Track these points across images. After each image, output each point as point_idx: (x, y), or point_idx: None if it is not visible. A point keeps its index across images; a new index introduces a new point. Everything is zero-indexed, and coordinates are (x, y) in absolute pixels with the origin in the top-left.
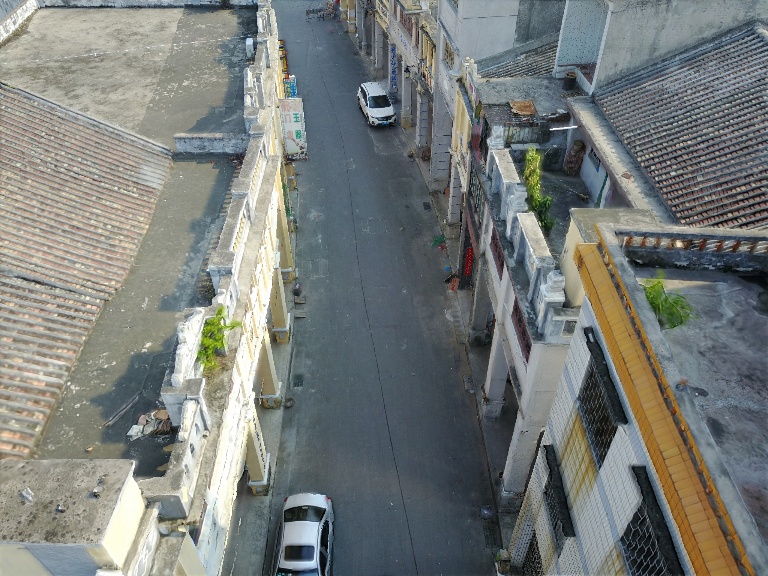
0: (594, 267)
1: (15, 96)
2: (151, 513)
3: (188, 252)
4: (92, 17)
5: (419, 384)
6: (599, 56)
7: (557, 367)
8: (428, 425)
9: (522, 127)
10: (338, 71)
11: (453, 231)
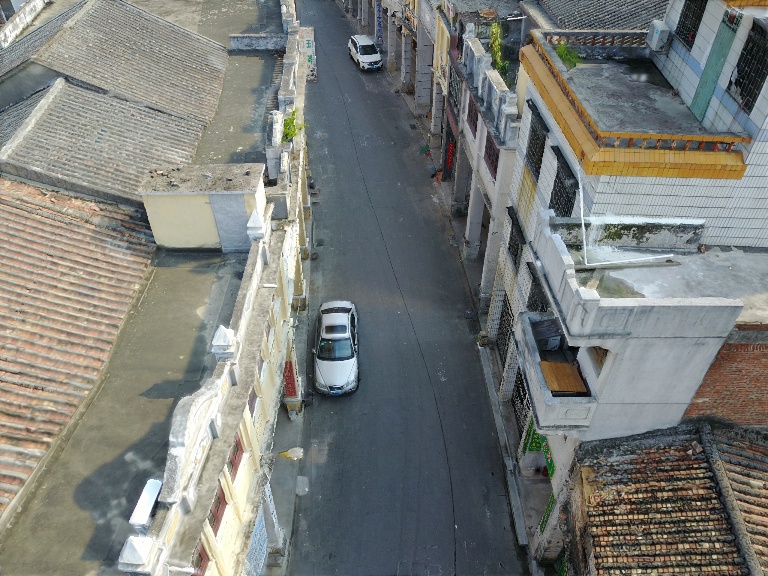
0: (530, 54)
1: (113, 3)
2: (270, 206)
3: (254, 104)
4: None
5: (414, 242)
6: None
7: None
8: (423, 266)
9: (488, 26)
10: (329, 30)
11: (436, 141)
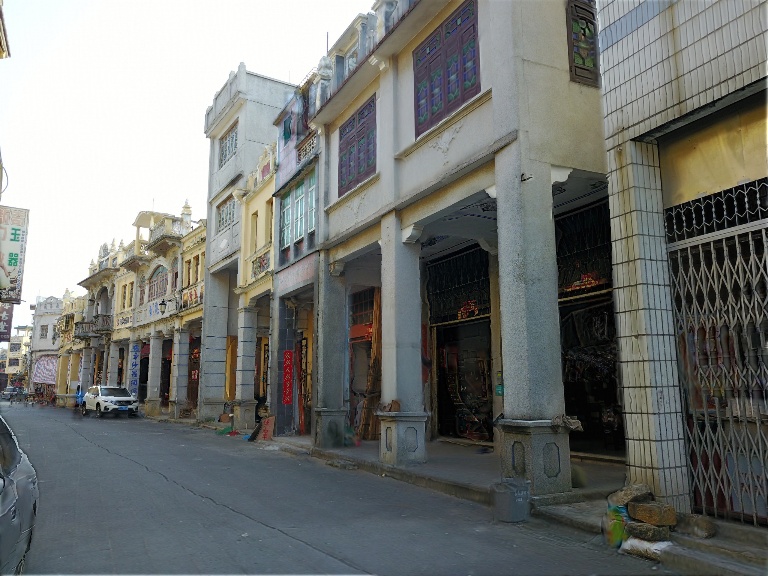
0: None
1: None
2: None
3: None
4: None
5: (244, 470)
6: None
7: (539, 8)
8: (286, 486)
9: None
10: None
11: (245, 416)
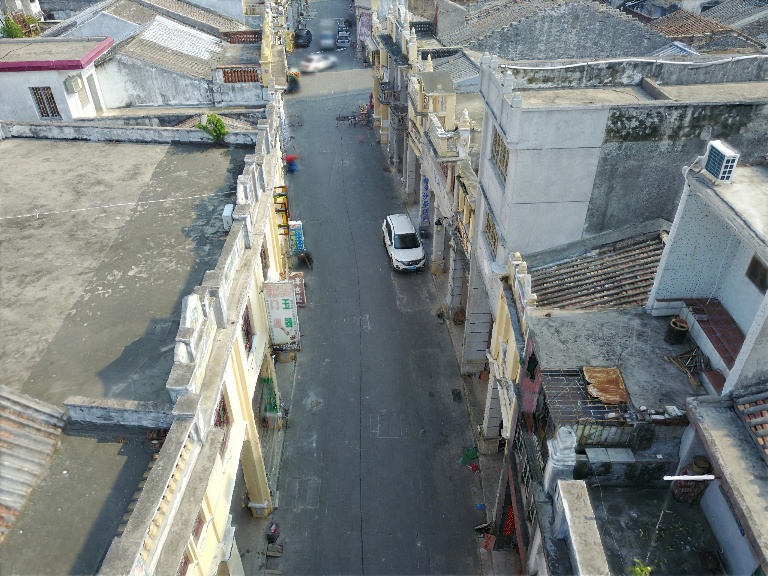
0: None
1: None
2: None
3: None
4: (58, 154)
5: None
6: (747, 343)
7: None
8: None
9: (606, 426)
10: (364, 192)
11: (489, 446)
